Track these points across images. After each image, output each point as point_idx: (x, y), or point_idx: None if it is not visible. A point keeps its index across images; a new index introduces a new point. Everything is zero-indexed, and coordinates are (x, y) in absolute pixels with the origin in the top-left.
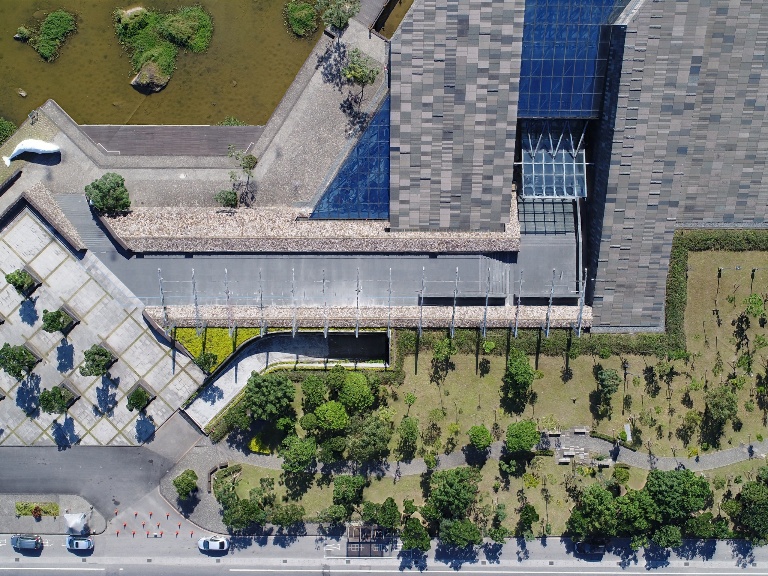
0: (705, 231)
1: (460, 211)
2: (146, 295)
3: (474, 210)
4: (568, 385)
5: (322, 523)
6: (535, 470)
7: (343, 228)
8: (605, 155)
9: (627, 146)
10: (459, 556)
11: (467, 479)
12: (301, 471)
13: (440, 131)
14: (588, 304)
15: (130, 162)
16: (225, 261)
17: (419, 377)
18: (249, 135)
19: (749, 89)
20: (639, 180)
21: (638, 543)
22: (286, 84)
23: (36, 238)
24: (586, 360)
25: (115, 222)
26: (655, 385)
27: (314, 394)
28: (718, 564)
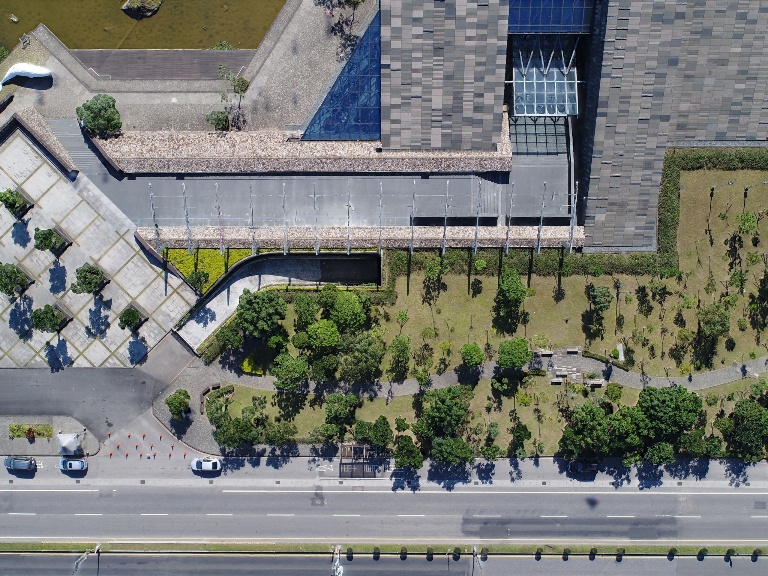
0: (697, 150)
1: (451, 130)
2: (138, 217)
3: (465, 129)
4: (560, 305)
5: (315, 444)
6: (527, 390)
7: (334, 148)
8: (596, 69)
9: (618, 57)
10: (452, 476)
11: (459, 396)
12: (293, 392)
13: (431, 47)
14: (580, 224)
15: (122, 86)
16: (217, 182)
17: (411, 298)
18: (240, 59)
19: (740, 2)
20: (630, 93)
21: (630, 460)
22: (277, 8)
23: (28, 160)
24: (578, 280)
25: (107, 143)
26: (648, 305)
27: (306, 312)
28: (711, 484)
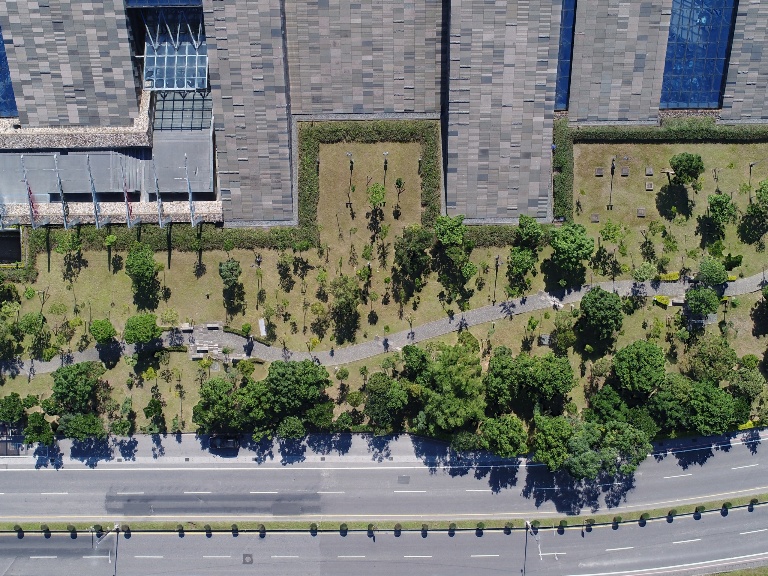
0: (335, 123)
1: (87, 106)
2: None
3: (101, 105)
4: (201, 280)
5: None
6: (169, 366)
7: None
8: None
9: (220, 29)
10: (95, 454)
11: (84, 372)
12: None
13: (50, 22)
14: None
15: None
16: None
17: (52, 275)
18: None
19: None
20: (240, 65)
21: (259, 434)
22: None
23: None
24: (219, 255)
25: None
26: (289, 279)
27: None
28: (354, 458)
